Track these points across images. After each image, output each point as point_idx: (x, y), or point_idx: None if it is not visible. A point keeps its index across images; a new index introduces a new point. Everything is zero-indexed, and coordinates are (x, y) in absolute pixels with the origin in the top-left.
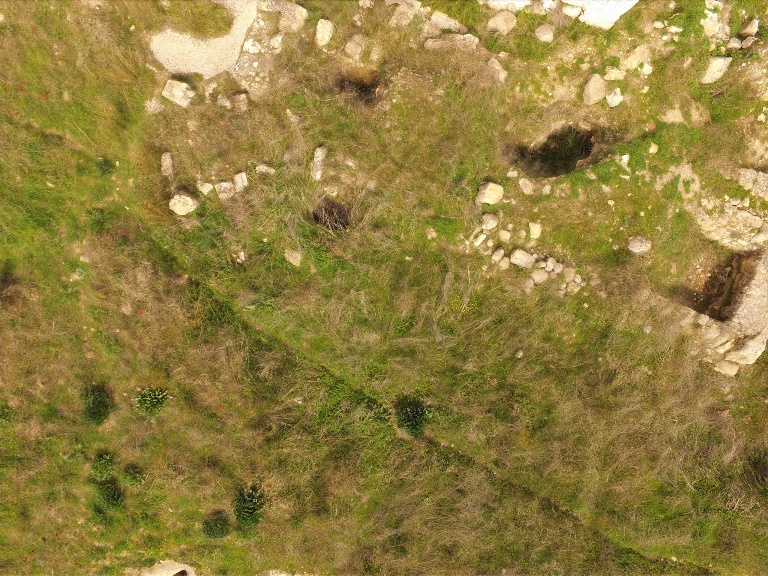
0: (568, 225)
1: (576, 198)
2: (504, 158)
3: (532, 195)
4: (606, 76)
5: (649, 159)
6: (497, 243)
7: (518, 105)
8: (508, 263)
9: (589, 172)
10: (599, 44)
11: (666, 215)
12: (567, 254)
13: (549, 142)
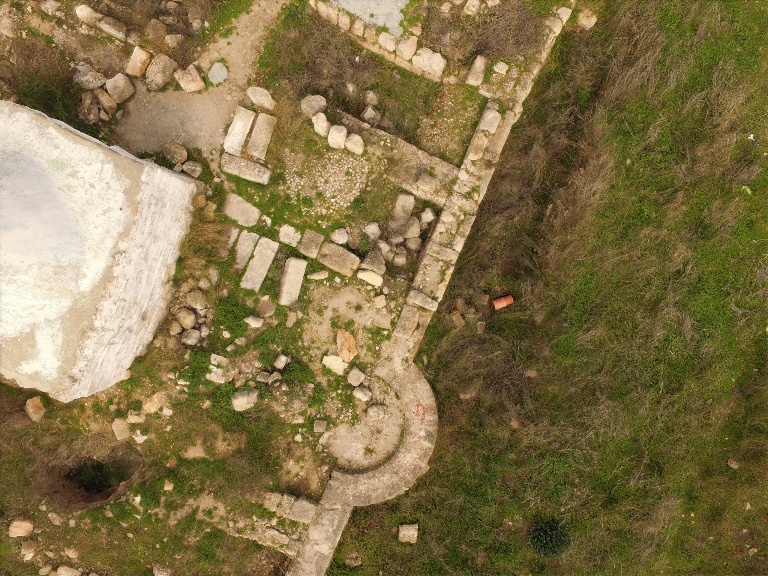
0: (99, 550)
1: (97, 532)
2: (39, 491)
3: (60, 527)
4: (126, 420)
5: (165, 496)
6: (47, 557)
7: (65, 433)
8: (56, 575)
9: (108, 509)
10: (125, 388)
11: (183, 545)
12: (110, 568)
13: (112, 453)
